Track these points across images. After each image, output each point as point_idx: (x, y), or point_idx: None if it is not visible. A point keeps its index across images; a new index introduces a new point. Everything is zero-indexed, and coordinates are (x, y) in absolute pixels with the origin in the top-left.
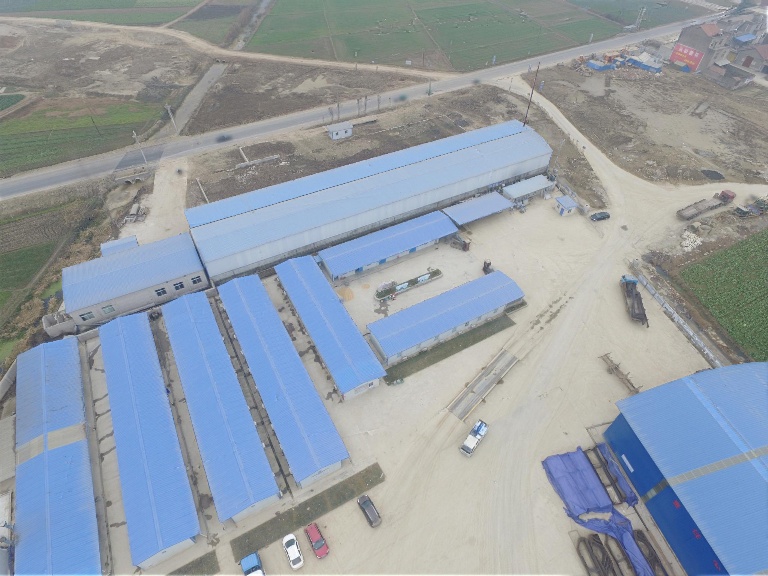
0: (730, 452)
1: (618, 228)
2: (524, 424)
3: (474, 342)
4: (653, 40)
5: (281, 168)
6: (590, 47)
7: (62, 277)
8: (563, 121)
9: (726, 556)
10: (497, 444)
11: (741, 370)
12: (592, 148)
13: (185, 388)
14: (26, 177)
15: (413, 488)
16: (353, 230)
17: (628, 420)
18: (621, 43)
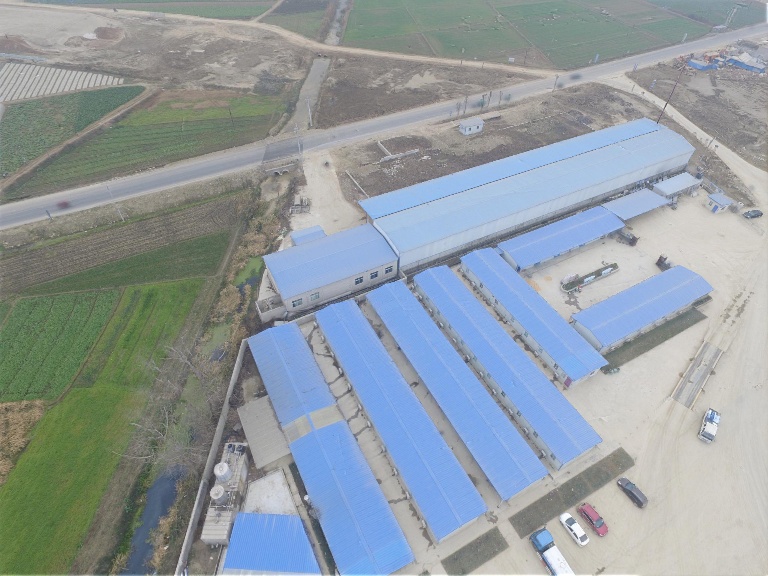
0: None
1: None
2: (750, 413)
3: (673, 334)
4: (746, 40)
5: (425, 162)
6: (684, 47)
7: (267, 264)
8: (683, 120)
9: None
10: (730, 432)
11: None
12: (721, 147)
13: (420, 373)
14: (179, 167)
15: (665, 472)
16: (520, 224)
17: None
18: (714, 43)
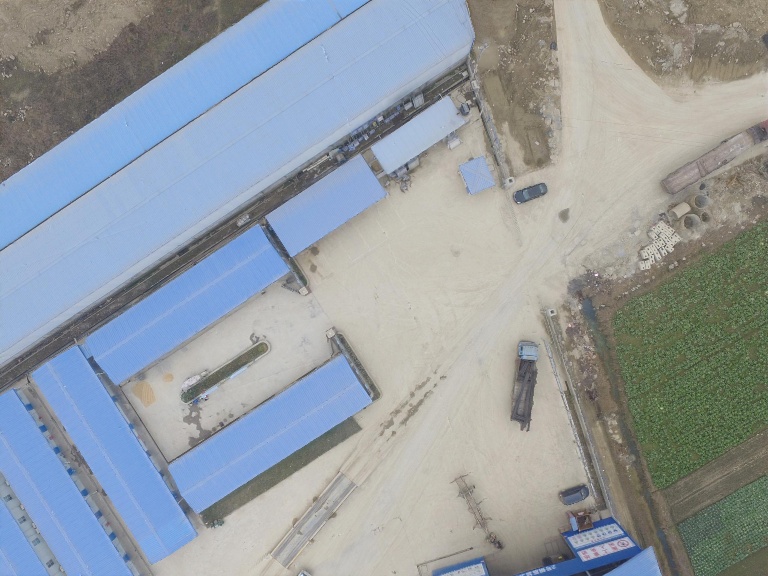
0: None
1: (553, 217)
2: (352, 565)
3: (307, 462)
4: None
5: None
6: None
7: None
8: None
9: None
10: None
11: None
12: None
13: None
14: None
15: None
16: (131, 277)
17: None
18: None
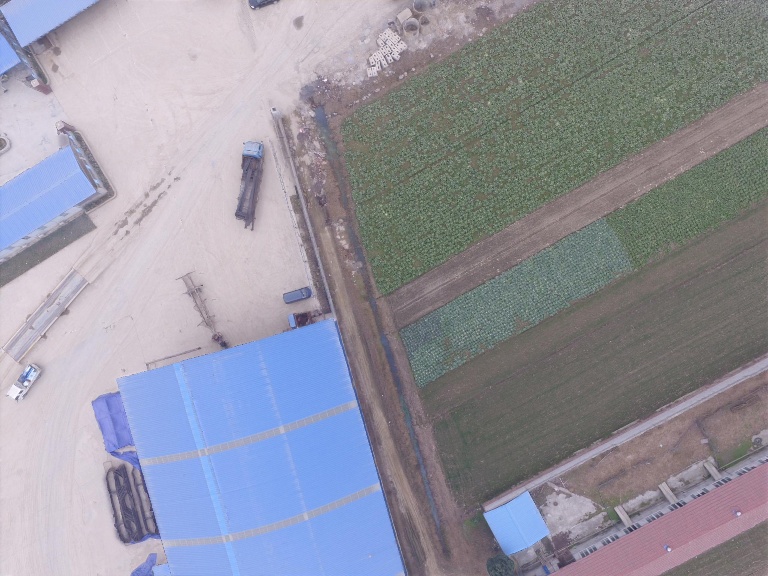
0: (188, 448)
1: (288, 24)
2: (83, 362)
3: (42, 258)
4: None
5: None
6: None
7: None
8: None
9: (162, 525)
10: (52, 384)
11: (243, 353)
12: None
13: None
14: None
15: None
16: None
17: (122, 400)
18: None
